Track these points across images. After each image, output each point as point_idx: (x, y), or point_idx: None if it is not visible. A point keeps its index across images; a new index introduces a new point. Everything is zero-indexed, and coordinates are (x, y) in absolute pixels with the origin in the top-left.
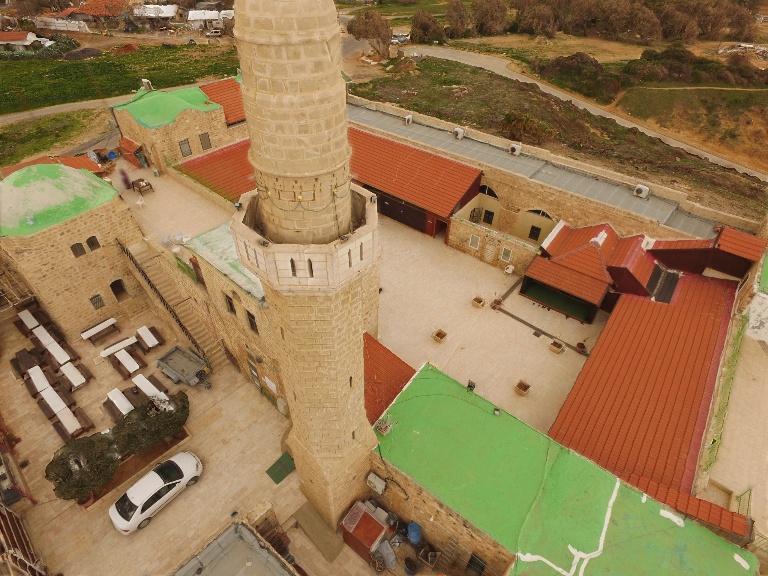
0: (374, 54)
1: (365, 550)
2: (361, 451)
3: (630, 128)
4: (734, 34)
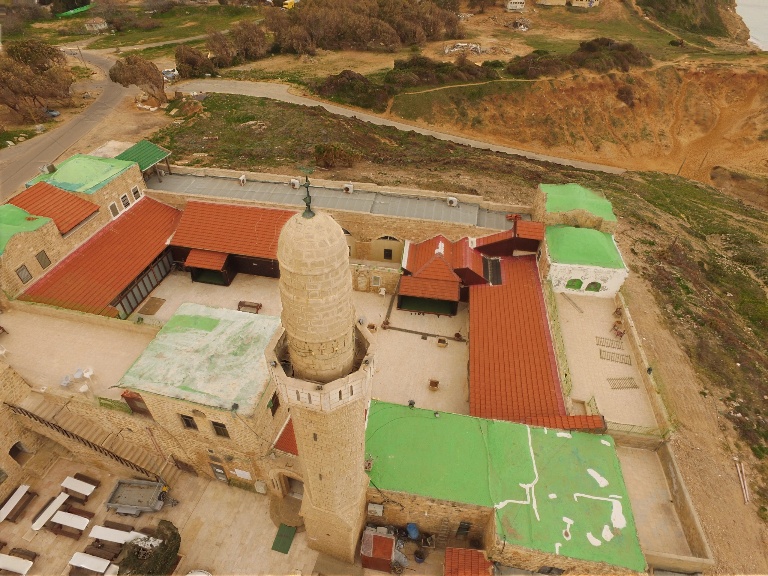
0: (148, 98)
1: (386, 563)
2: (363, 492)
3: (409, 132)
4: (450, 33)
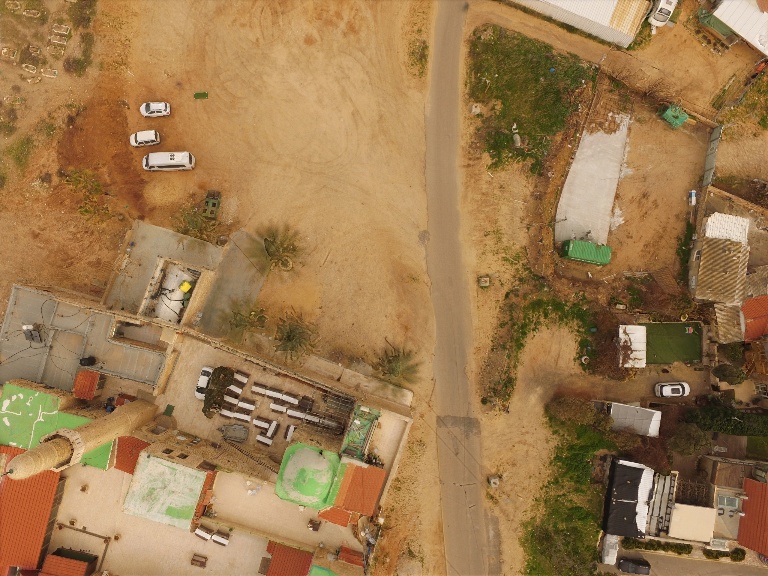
0: None
1: None
2: None
3: None
4: None
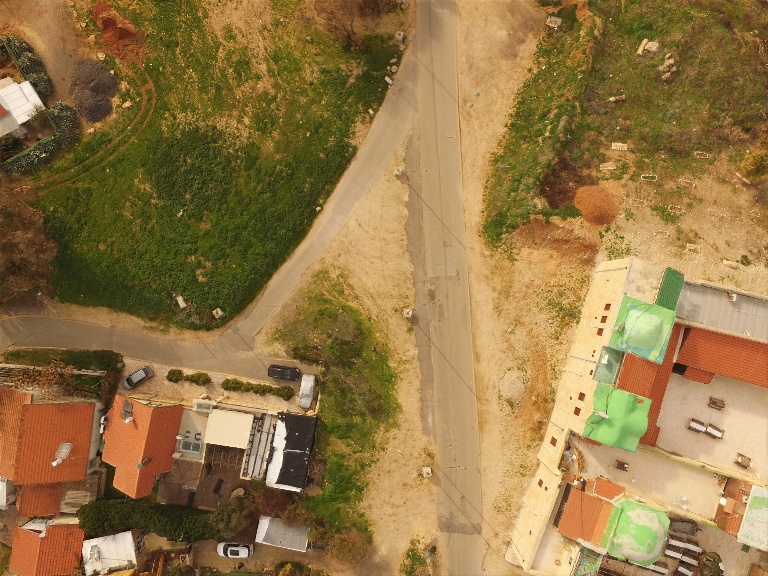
0: None
1: None
2: None
3: None
4: None
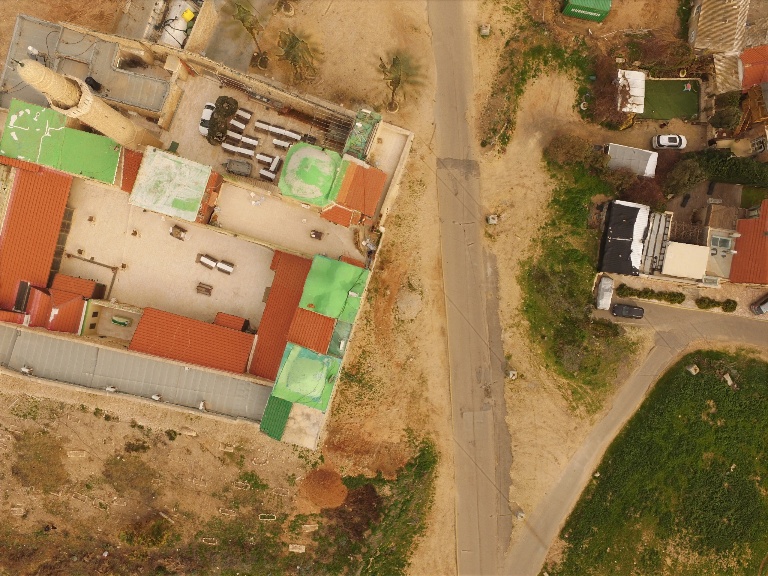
0: None
1: None
2: None
3: None
4: None
